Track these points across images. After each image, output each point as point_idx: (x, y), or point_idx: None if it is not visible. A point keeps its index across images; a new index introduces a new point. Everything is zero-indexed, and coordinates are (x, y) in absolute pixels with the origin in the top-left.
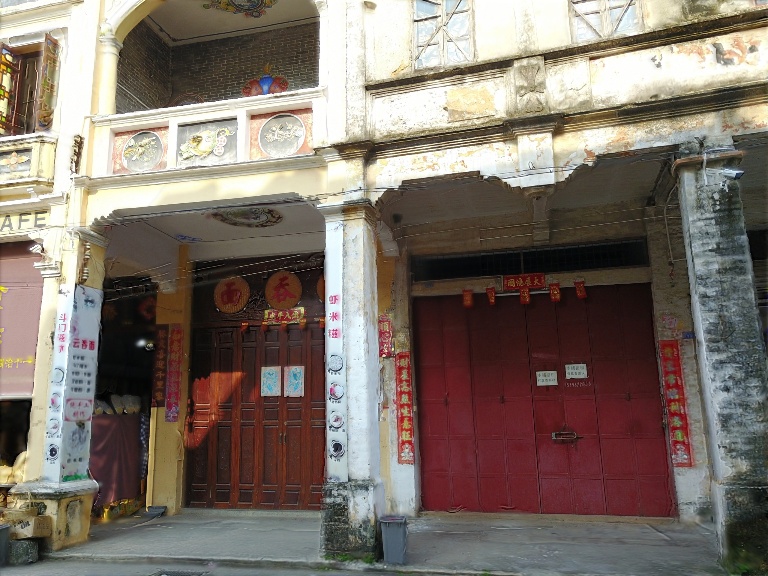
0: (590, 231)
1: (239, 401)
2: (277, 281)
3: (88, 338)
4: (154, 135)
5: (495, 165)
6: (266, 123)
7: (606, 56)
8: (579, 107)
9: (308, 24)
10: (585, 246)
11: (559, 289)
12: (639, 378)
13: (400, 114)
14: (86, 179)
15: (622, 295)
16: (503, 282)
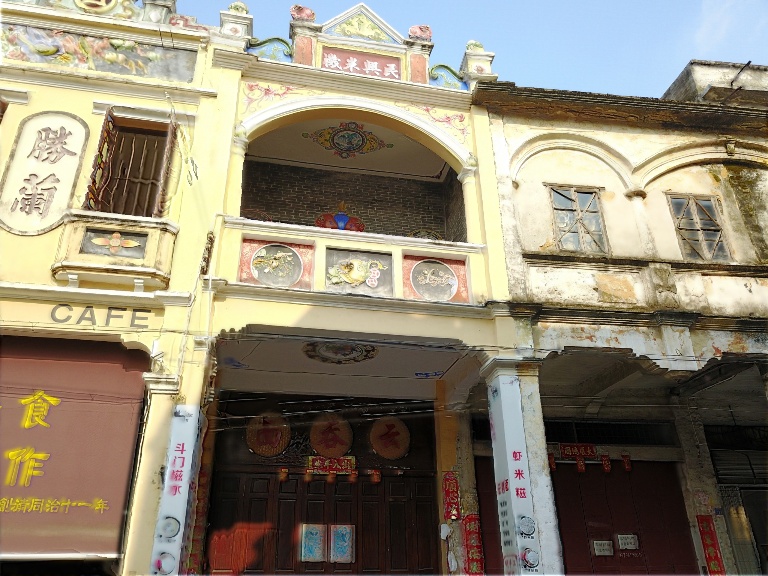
0: (629, 410)
1: (273, 567)
2: (326, 424)
3: (196, 477)
4: (291, 251)
5: (644, 346)
6: (417, 265)
7: (712, 275)
8: (702, 311)
9: (384, 177)
10: (626, 423)
11: (610, 461)
12: (680, 550)
13: (554, 285)
14: (222, 283)
15: (657, 471)
16: (560, 449)
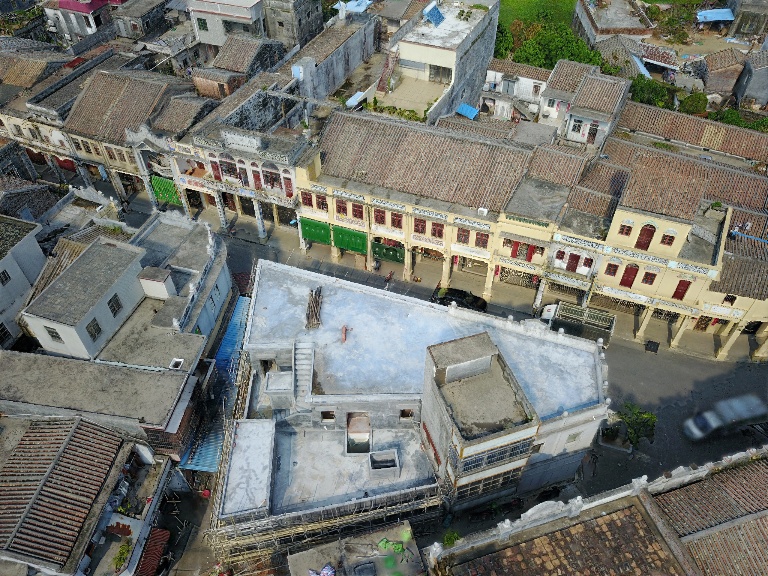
0: None
1: None
2: None
3: None
4: None
5: None
6: None
7: None
8: None
9: None
10: None
11: None
12: None
13: (19, 139)
14: None
15: None
16: None
